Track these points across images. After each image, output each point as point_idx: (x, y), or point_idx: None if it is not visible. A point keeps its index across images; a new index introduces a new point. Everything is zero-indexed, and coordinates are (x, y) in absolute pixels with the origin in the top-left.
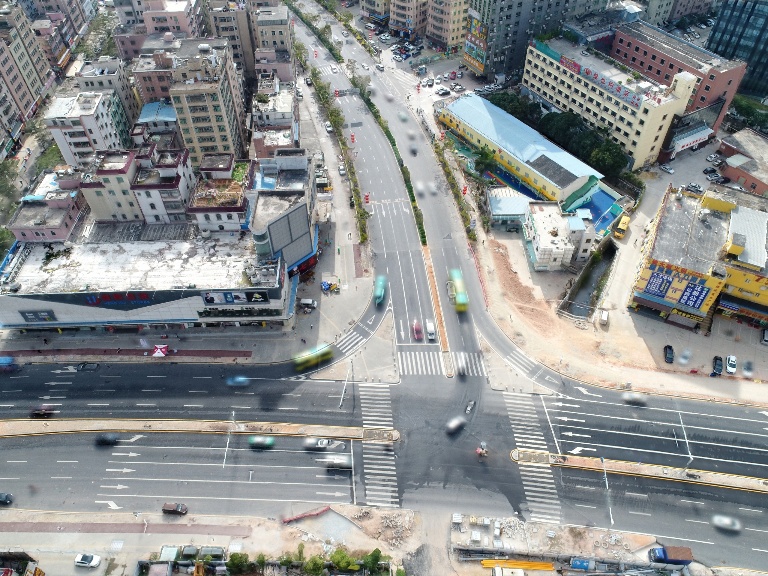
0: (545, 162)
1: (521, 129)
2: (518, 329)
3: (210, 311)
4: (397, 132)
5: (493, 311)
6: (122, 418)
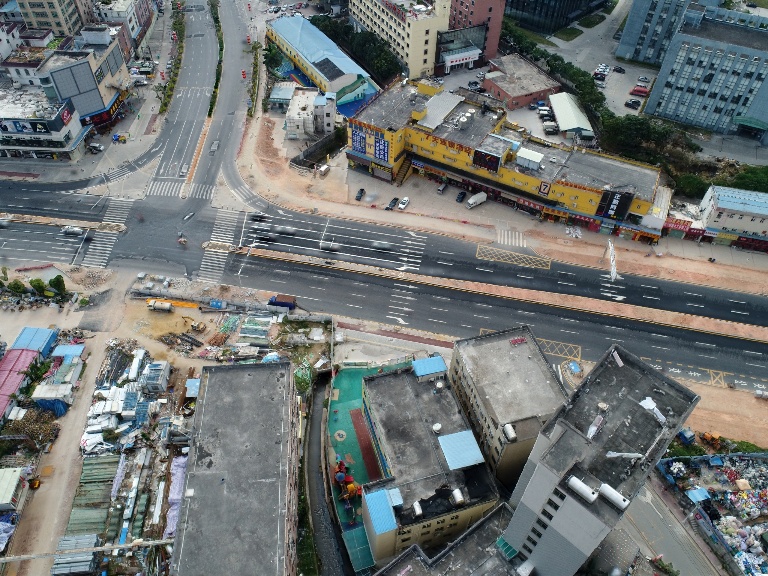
0: (326, 63)
1: (322, 41)
2: (253, 173)
3: (9, 141)
4: (230, 42)
5: (240, 161)
6: None
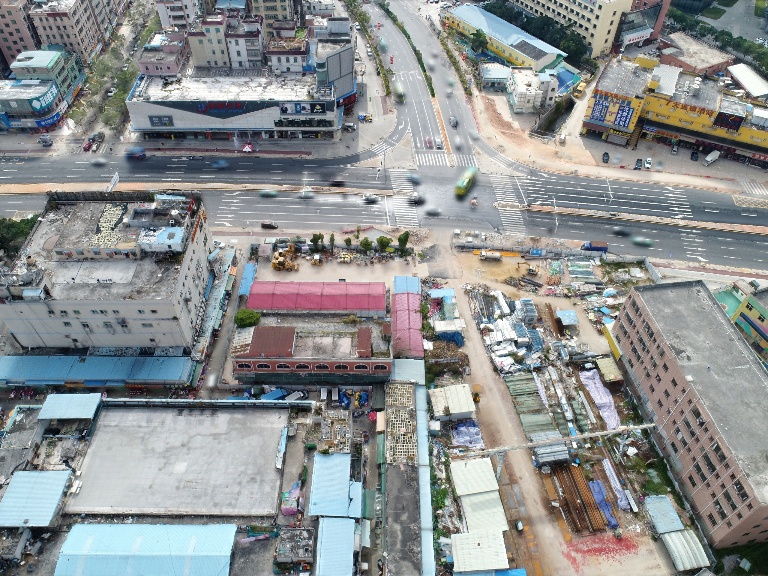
0: (524, 45)
1: (507, 26)
2: (501, 143)
3: (282, 122)
4: (411, 31)
5: (483, 134)
6: (226, 183)
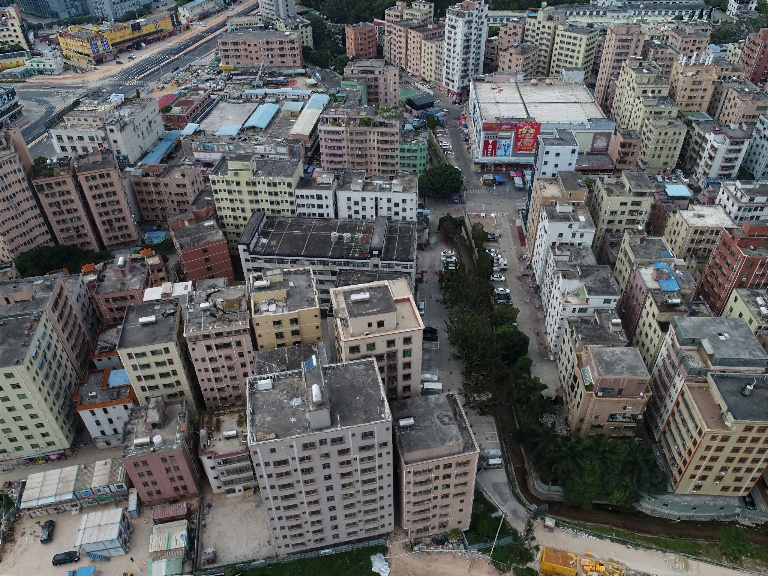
0: (5, 56)
1: None
2: (81, 80)
3: None
4: None
5: None
6: None
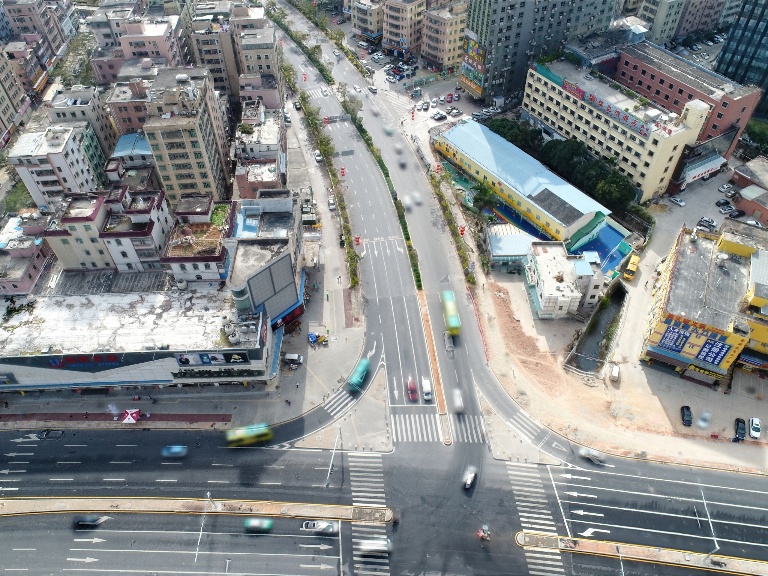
0: (548, 197)
1: (522, 159)
2: (522, 387)
3: (186, 371)
4: (390, 161)
5: (494, 366)
6: (87, 496)
